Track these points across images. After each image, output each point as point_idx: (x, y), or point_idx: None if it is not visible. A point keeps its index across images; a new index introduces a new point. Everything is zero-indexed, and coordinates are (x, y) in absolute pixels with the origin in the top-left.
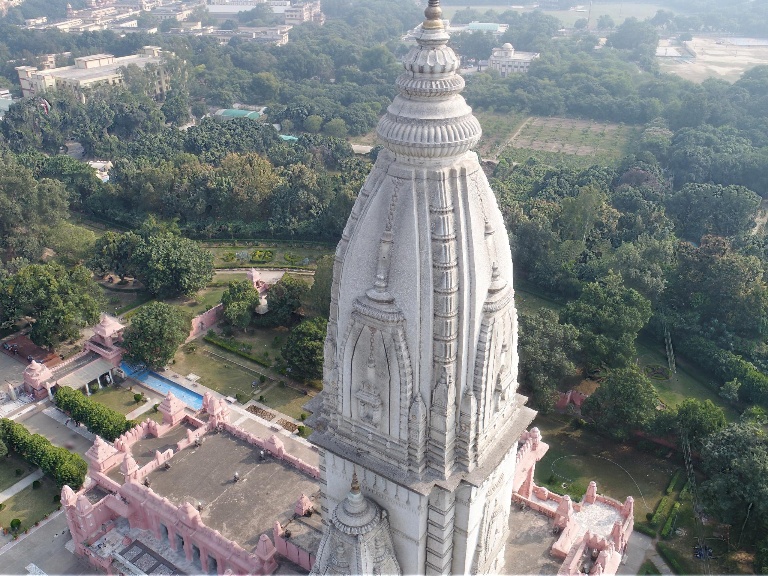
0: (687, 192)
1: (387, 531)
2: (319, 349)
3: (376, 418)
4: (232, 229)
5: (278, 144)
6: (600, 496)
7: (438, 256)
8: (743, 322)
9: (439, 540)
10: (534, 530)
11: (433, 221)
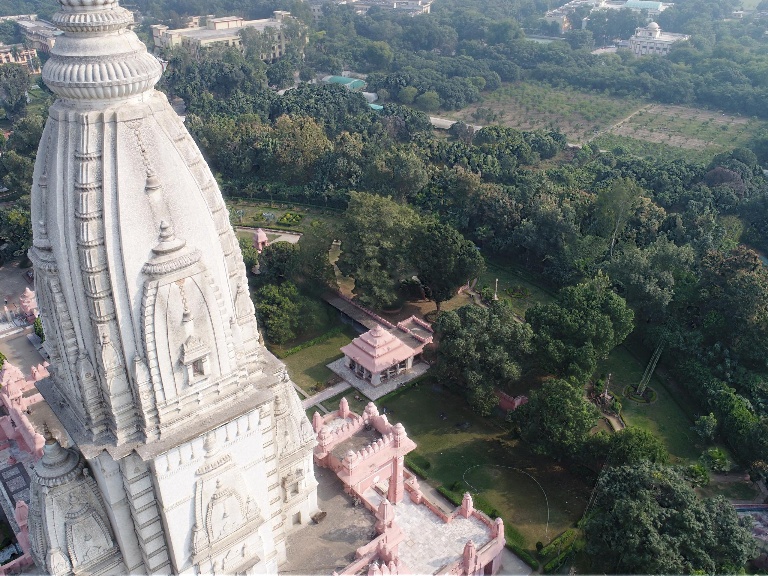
0: (766, 197)
1: (92, 489)
2: (273, 313)
3: (60, 370)
4: (271, 190)
5: (365, 113)
6: (476, 511)
7: (77, 205)
8: (749, 351)
9: (133, 509)
10: (353, 529)
11: (76, 167)
